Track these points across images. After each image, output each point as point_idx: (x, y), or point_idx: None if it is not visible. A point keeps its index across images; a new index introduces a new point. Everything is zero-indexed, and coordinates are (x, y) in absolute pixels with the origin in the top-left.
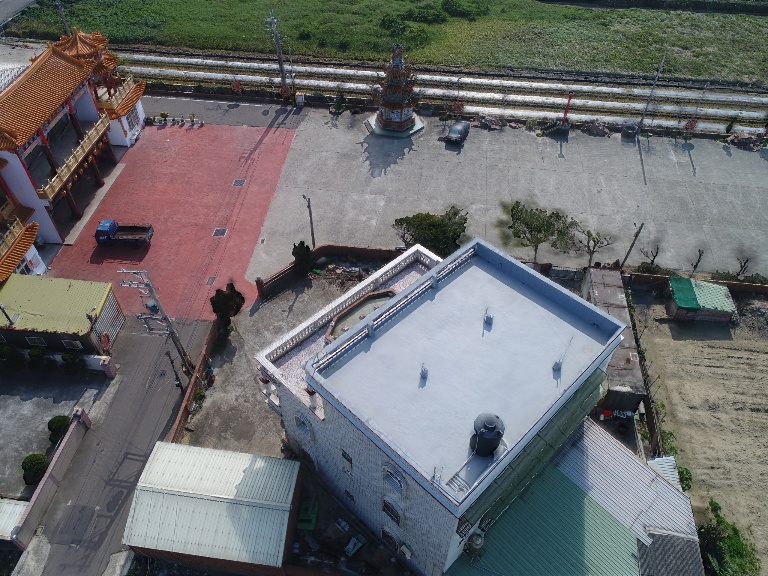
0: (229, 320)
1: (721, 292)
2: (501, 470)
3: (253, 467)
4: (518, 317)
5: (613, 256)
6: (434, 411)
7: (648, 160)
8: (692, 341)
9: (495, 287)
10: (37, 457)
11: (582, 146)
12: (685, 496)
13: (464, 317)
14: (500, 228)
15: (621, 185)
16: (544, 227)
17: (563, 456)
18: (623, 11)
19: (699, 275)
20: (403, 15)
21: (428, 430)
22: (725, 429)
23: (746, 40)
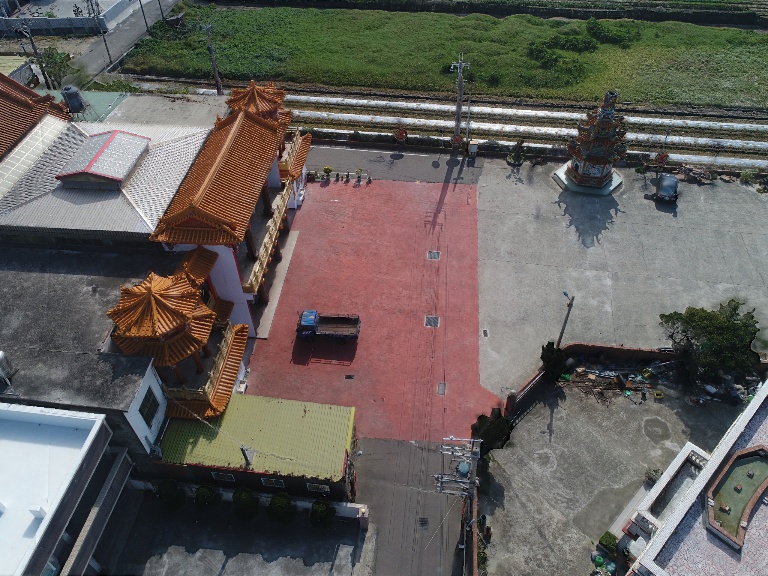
0: None
1: None
2: None
3: None
4: None
5: None
6: None
7: None
8: None
9: None
10: None
11: None
12: None
13: None
14: (762, 316)
15: None
16: None
17: None
18: None
19: None
20: (549, 43)
21: None
22: None
23: None
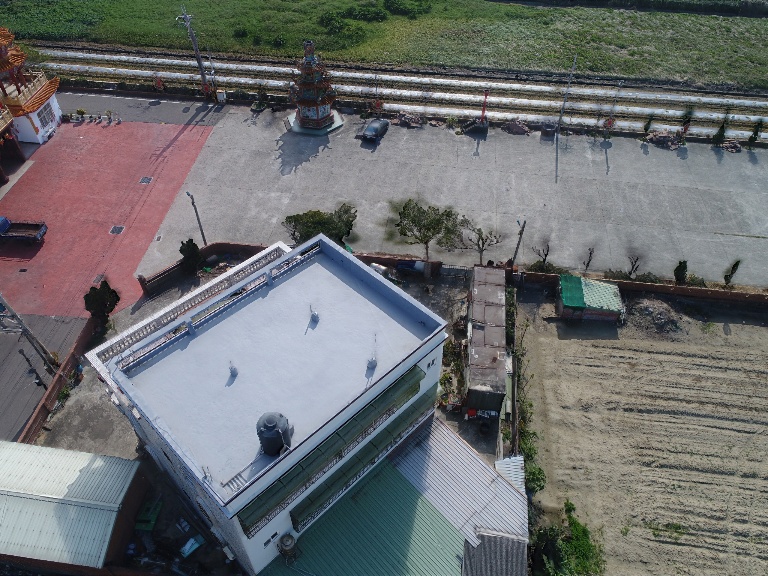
0: (105, 318)
1: (610, 291)
2: (286, 470)
3: (91, 467)
4: (347, 315)
5: (510, 254)
6: (234, 410)
7: (563, 158)
8: (577, 340)
9: (332, 284)
10: None
11: (499, 144)
12: (523, 497)
13: (292, 315)
14: None
15: (531, 183)
16: (432, 225)
17: (404, 456)
18: (566, 9)
19: (593, 274)
20: (343, 13)
21: (223, 429)
22: (594, 429)
23: (685, 39)
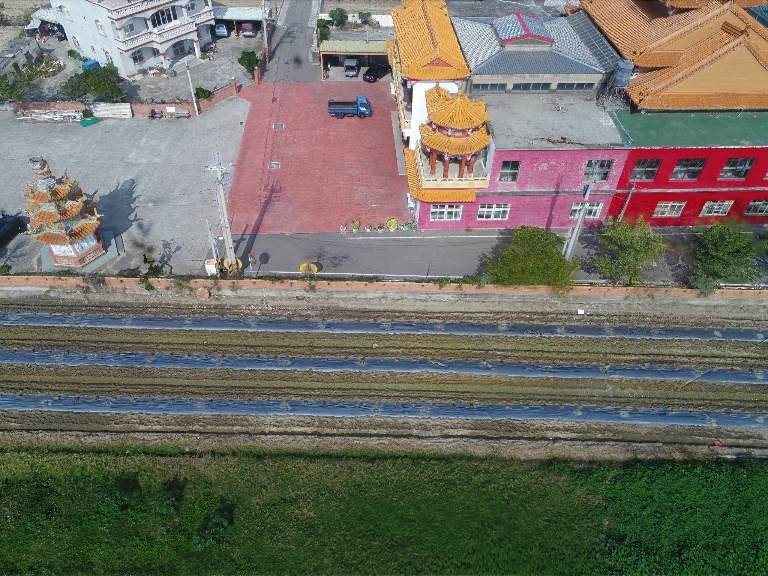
0: None
1: None
2: None
3: (222, 16)
4: None
5: None
6: None
7: None
8: None
9: None
10: (320, 20)
11: None
12: None
13: None
14: (29, 142)
15: None
16: None
17: None
18: None
19: None
20: None
21: None
22: None
23: None
